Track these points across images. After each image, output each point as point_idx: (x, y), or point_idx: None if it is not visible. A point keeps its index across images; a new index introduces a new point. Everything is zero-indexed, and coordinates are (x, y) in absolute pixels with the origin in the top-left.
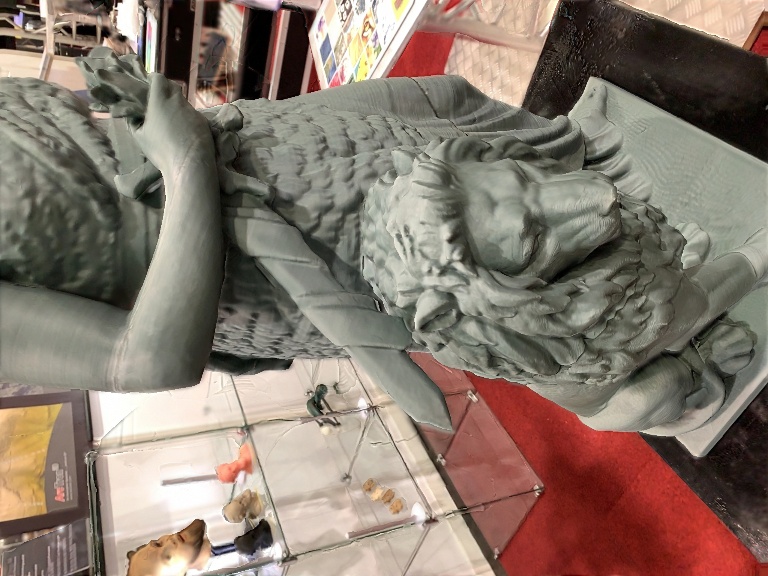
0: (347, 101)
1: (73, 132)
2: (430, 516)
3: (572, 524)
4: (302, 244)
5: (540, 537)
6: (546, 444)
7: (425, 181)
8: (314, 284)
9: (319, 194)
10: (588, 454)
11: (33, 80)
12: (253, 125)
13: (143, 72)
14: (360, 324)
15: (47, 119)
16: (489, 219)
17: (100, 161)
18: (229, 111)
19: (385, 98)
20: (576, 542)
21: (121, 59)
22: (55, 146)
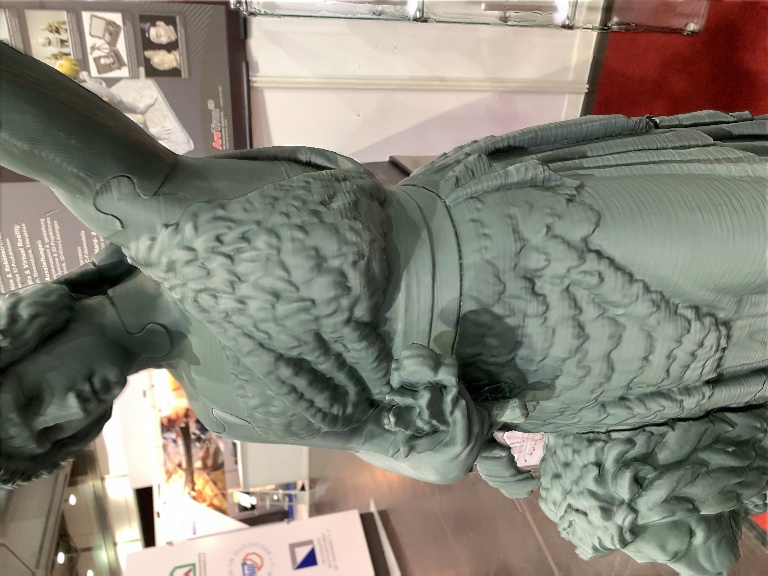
0: (696, 290)
1: (361, 367)
2: (569, 23)
3: (685, 82)
4: (505, 462)
5: (654, 56)
6: (740, 4)
7: (605, 544)
8: (496, 472)
9: (550, 431)
10: (756, 62)
11: (331, 298)
12: (544, 364)
13: (451, 413)
14: (509, 485)
15: (339, 360)
16: (626, 550)
17: (377, 392)
18: (516, 420)
19: (750, 288)
20: (674, 94)
21: (437, 381)
22: (343, 413)
